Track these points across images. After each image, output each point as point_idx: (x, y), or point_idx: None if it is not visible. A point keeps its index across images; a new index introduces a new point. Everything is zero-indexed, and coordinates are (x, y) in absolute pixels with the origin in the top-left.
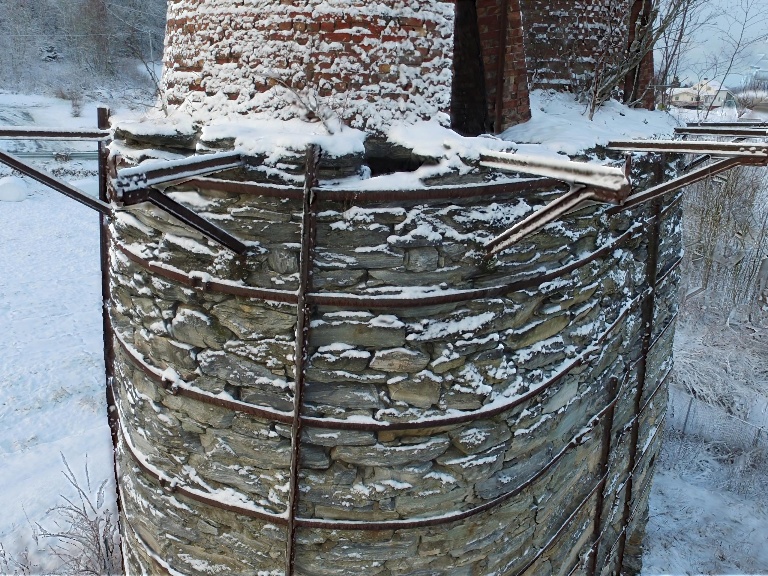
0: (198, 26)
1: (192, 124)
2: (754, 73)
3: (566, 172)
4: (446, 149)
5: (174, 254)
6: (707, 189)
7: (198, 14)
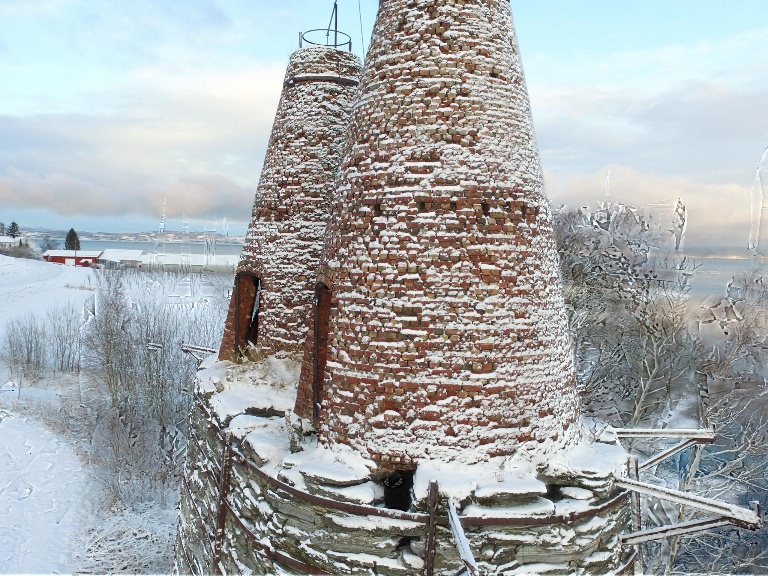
0: (520, 392)
1: (536, 468)
2: (154, 257)
3: (680, 434)
4: (613, 434)
5: (592, 571)
6: (146, 357)
7: (520, 384)
